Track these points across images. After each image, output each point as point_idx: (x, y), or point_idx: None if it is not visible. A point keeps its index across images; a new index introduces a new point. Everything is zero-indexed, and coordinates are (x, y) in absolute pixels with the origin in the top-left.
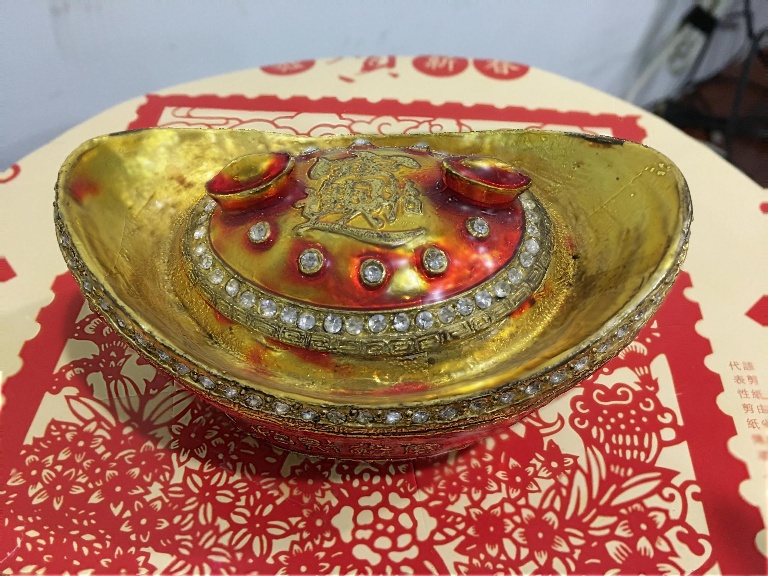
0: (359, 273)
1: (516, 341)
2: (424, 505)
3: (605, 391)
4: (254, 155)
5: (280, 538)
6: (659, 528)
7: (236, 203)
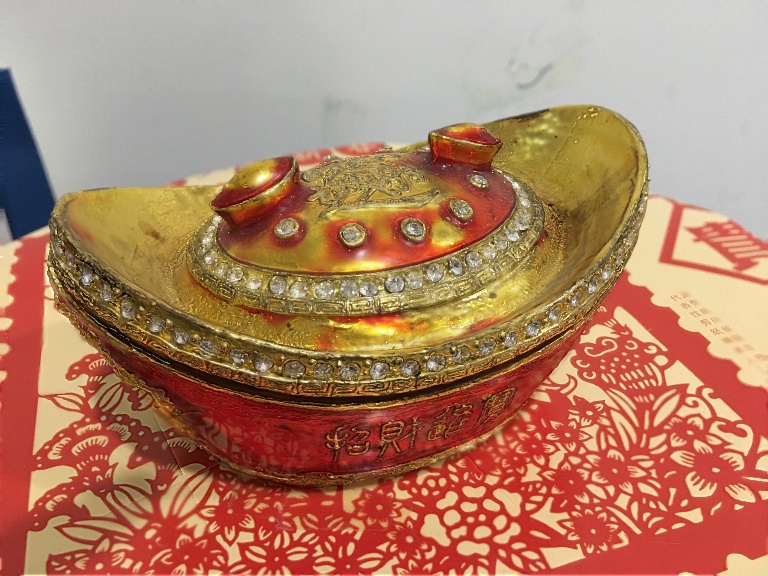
0: (402, 232)
1: (549, 266)
2: (500, 486)
3: (593, 346)
4: (256, 162)
5: (378, 568)
6: (702, 429)
7: (251, 210)
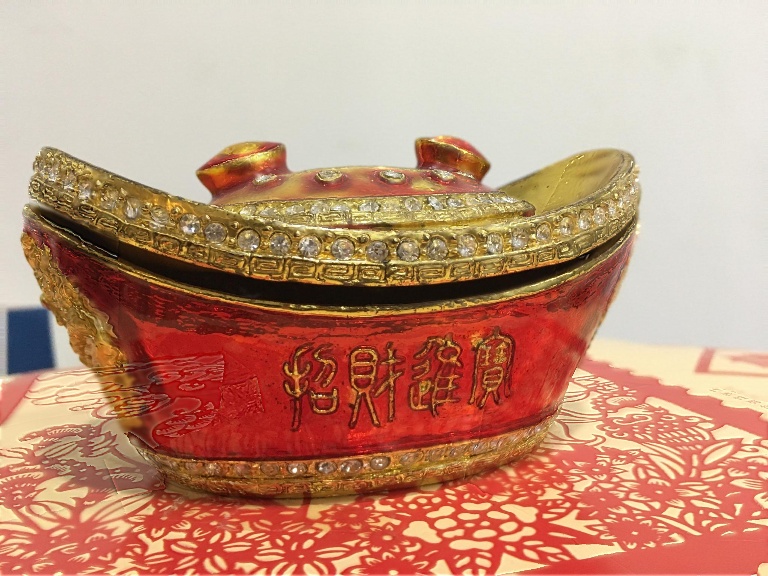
0: (380, 176)
1: None
2: (509, 502)
3: (622, 419)
4: None
5: (341, 558)
6: (767, 465)
7: (233, 172)
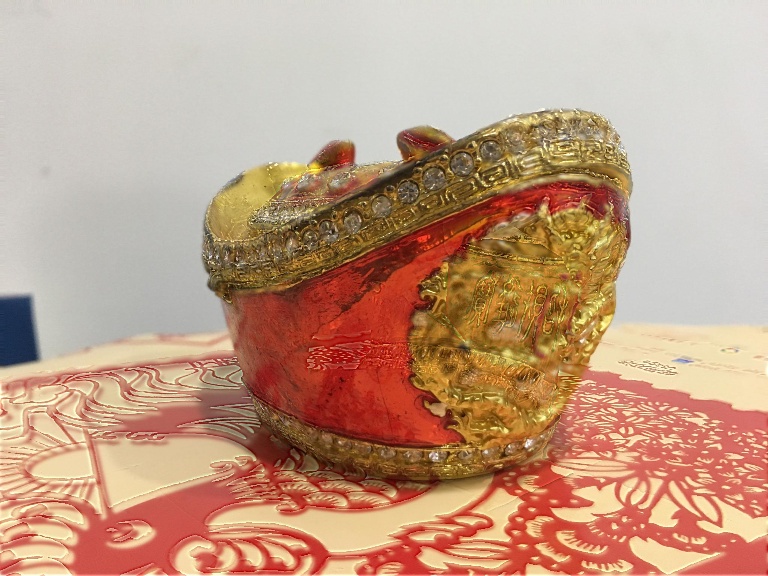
0: None
1: None
2: None
3: None
4: None
5: None
6: None
7: None
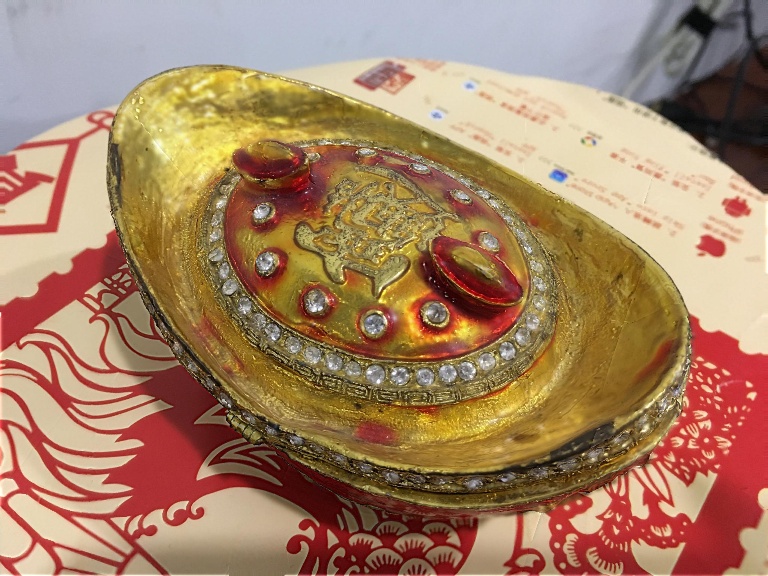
0: (430, 173)
1: None
2: None
3: None
4: (467, 259)
5: None
6: None
7: None
